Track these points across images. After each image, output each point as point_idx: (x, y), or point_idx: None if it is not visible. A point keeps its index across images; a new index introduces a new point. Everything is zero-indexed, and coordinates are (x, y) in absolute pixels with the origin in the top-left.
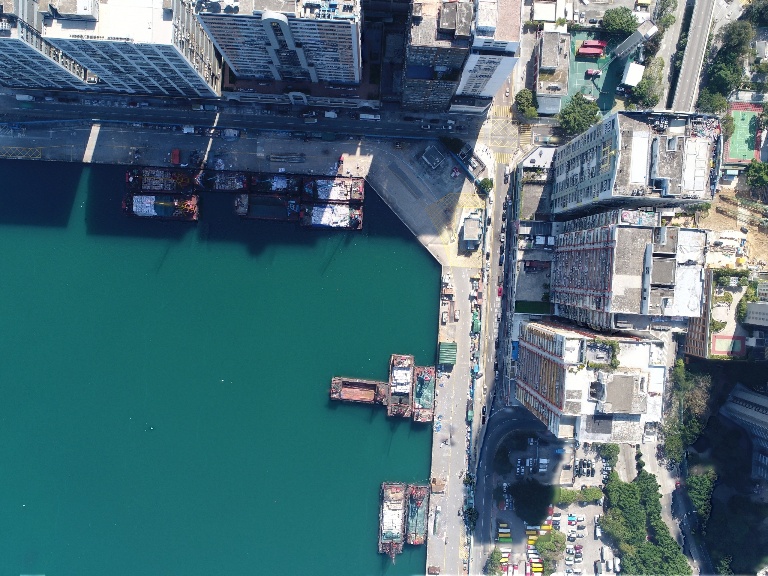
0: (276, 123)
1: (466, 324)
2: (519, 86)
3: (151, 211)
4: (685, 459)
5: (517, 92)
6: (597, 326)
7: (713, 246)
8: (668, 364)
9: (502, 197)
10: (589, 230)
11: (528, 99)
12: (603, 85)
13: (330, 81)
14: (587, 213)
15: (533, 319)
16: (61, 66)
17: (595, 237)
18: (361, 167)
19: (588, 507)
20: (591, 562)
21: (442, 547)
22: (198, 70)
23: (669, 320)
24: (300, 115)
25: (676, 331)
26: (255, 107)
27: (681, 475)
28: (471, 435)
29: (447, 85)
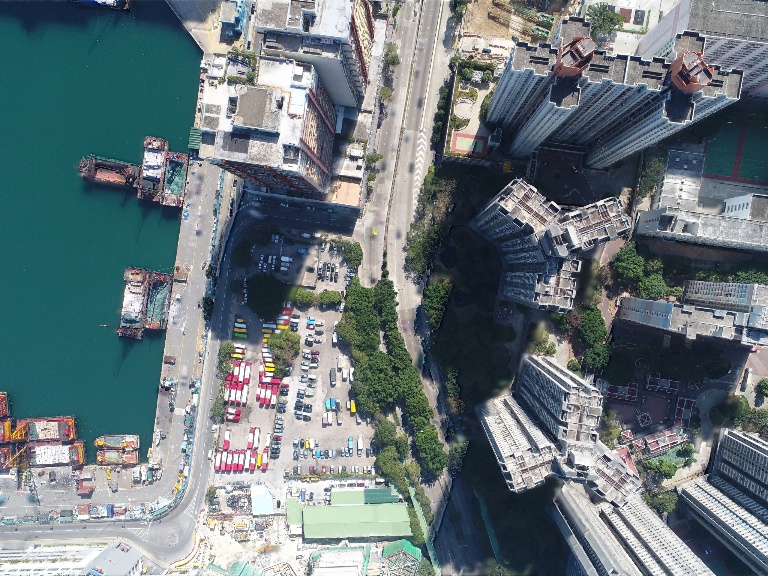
0: None
1: None
2: None
3: None
4: None
5: None
6: None
7: (481, 53)
8: (424, 173)
9: None
10: None
11: None
12: None
13: None
14: None
15: None
16: None
17: None
18: None
19: (328, 313)
20: (327, 370)
21: (180, 337)
22: None
23: (320, 43)
24: None
25: (327, 56)
26: None
27: None
28: None
29: None
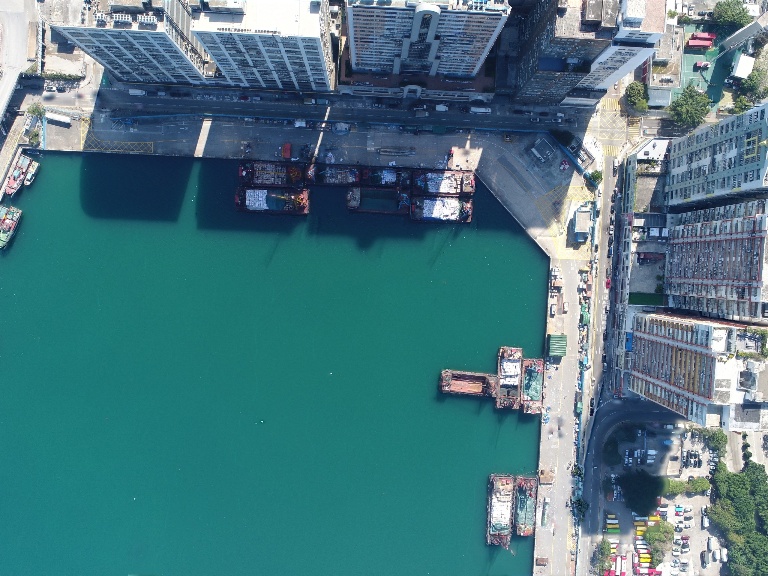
0: (386, 117)
1: (574, 316)
2: (628, 79)
3: (263, 205)
4: None
5: (626, 85)
6: (735, 316)
7: None
8: None
9: (610, 189)
10: (724, 221)
11: (640, 91)
12: (711, 77)
13: (446, 74)
14: (709, 204)
15: (647, 311)
16: (189, 60)
17: (734, 227)
18: (470, 160)
19: (695, 498)
20: (698, 552)
21: (550, 538)
22: (326, 63)
23: None
24: (411, 109)
25: None
26: (366, 101)
27: None
28: (580, 427)
29: (575, 77)
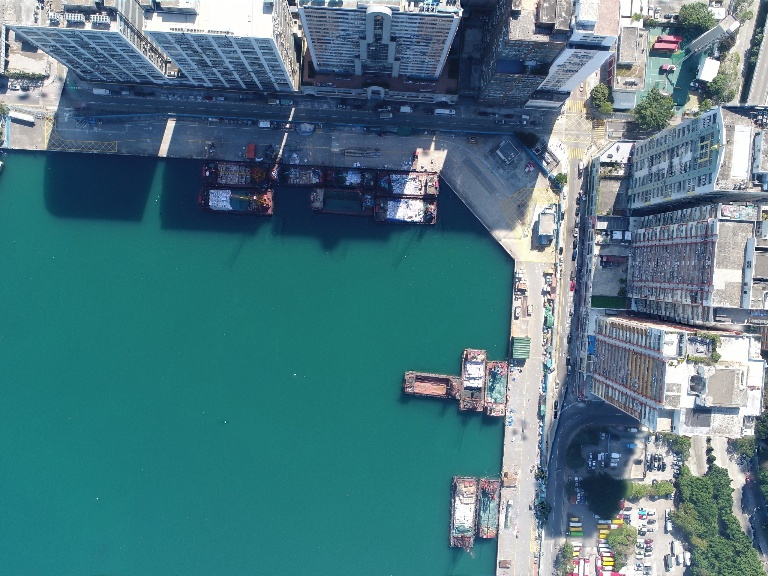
0: (351, 118)
1: (539, 319)
2: (593, 81)
3: (227, 205)
4: (756, 454)
5: (591, 87)
6: (690, 320)
7: None
8: None
9: (575, 192)
10: (680, 224)
11: (604, 94)
12: (677, 80)
13: (409, 76)
14: (670, 208)
15: (609, 314)
16: (148, 60)
17: (688, 231)
18: (435, 162)
19: (659, 501)
20: (661, 556)
21: (513, 541)
22: (285, 64)
23: (767, 314)
24: (375, 110)
25: None
26: (330, 102)
27: (751, 470)
28: (543, 429)
29: (534, 80)
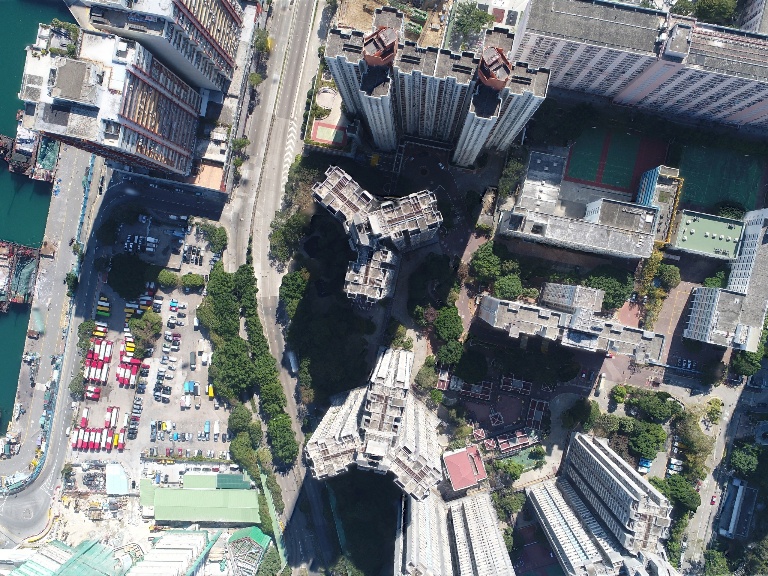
0: None
1: None
2: None
3: None
4: None
5: None
6: None
7: None
8: (293, 162)
9: None
10: None
11: None
12: None
13: None
14: None
15: None
16: None
17: None
18: None
19: (192, 296)
20: (188, 353)
21: (45, 313)
22: None
23: (145, 21)
24: None
25: (152, 34)
26: None
27: None
28: None
29: None
